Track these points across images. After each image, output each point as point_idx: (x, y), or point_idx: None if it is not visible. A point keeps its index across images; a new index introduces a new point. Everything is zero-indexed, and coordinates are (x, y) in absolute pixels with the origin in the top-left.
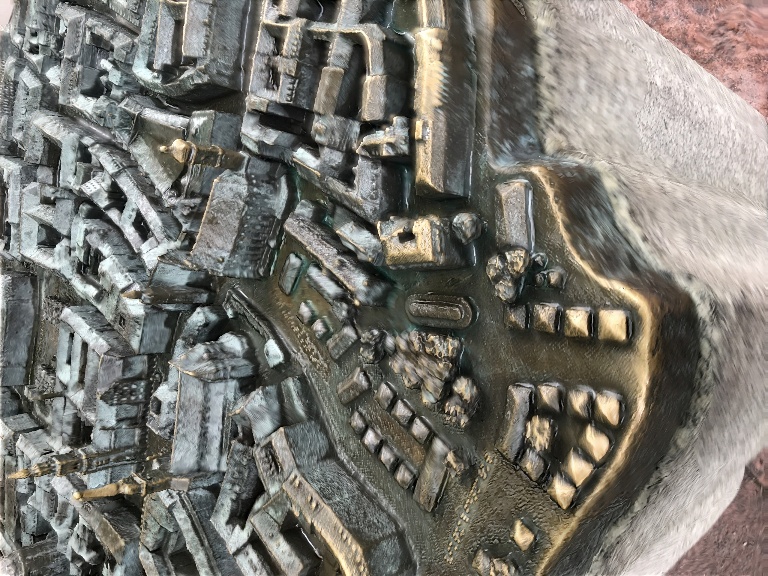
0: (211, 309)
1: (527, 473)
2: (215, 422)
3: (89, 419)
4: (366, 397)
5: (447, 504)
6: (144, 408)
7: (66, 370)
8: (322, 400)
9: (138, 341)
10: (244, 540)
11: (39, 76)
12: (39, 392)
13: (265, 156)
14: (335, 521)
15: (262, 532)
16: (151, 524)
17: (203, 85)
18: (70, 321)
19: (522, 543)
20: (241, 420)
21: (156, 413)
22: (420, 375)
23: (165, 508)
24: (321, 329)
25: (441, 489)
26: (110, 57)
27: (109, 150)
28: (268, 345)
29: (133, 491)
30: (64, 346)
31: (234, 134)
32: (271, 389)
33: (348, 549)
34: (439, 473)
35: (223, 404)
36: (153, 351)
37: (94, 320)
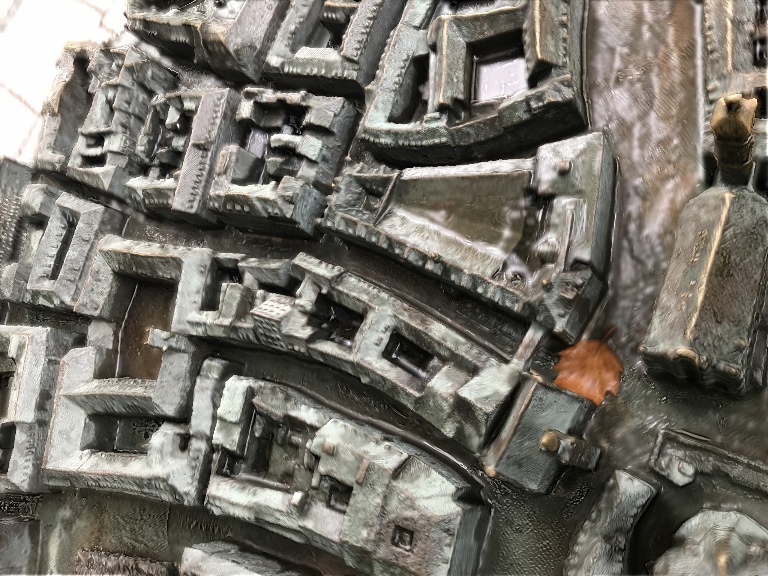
0: (630, 474)
1: None
2: None
3: None
4: None
5: None
6: None
7: None
8: None
9: (445, 574)
10: None
11: (90, 201)
12: None
13: (761, 169)
14: None
15: None
16: None
17: (555, 108)
18: (210, 571)
19: None
20: None
21: None
22: None
23: None
24: None
25: None
26: (285, 132)
27: (303, 252)
28: None
29: None
30: None
31: (609, 177)
32: None
33: None
34: None
35: None
36: None
37: (255, 563)
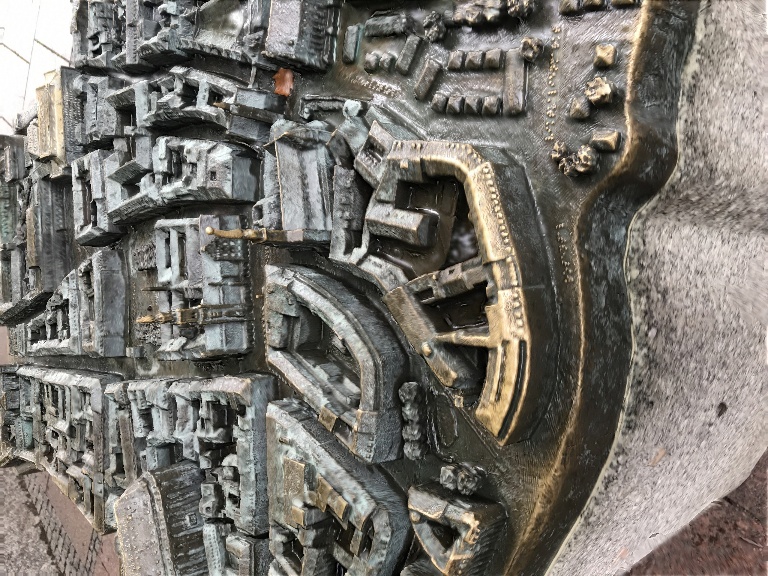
0: (289, 120)
1: (591, 3)
2: (314, 187)
3: (197, 286)
4: (440, 80)
5: (534, 97)
6: (244, 267)
7: (167, 272)
8: (403, 116)
9: (230, 185)
10: (364, 252)
11: None
12: (140, 348)
13: None
14: (441, 144)
15: (379, 218)
16: (274, 320)
17: None
18: (164, 224)
19: (605, 56)
20: (337, 147)
21: (259, 220)
22: (480, 4)
23: (284, 289)
24: (388, 57)
25: (525, 88)
26: None
27: None
28: (345, 105)
29: (256, 234)
30: (162, 253)
31: None
32: (357, 119)
33: (458, 151)
34: (519, 71)
35: (318, 170)
36: (244, 198)
37: None
